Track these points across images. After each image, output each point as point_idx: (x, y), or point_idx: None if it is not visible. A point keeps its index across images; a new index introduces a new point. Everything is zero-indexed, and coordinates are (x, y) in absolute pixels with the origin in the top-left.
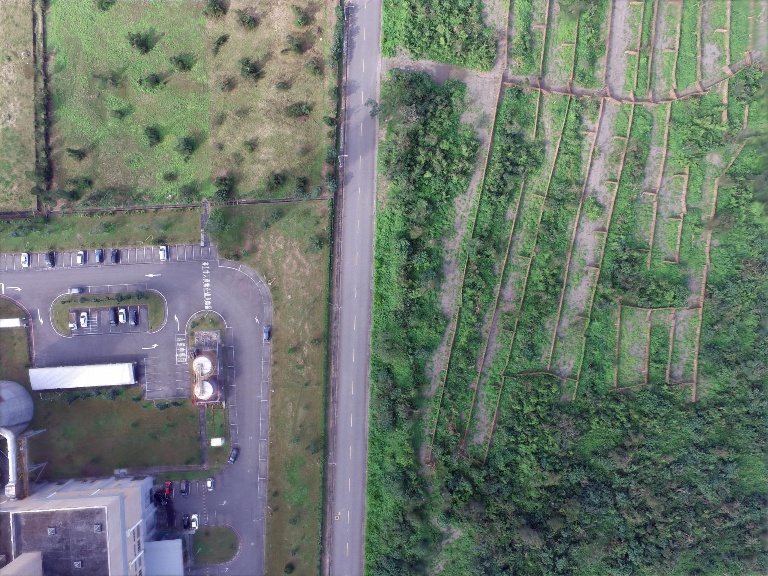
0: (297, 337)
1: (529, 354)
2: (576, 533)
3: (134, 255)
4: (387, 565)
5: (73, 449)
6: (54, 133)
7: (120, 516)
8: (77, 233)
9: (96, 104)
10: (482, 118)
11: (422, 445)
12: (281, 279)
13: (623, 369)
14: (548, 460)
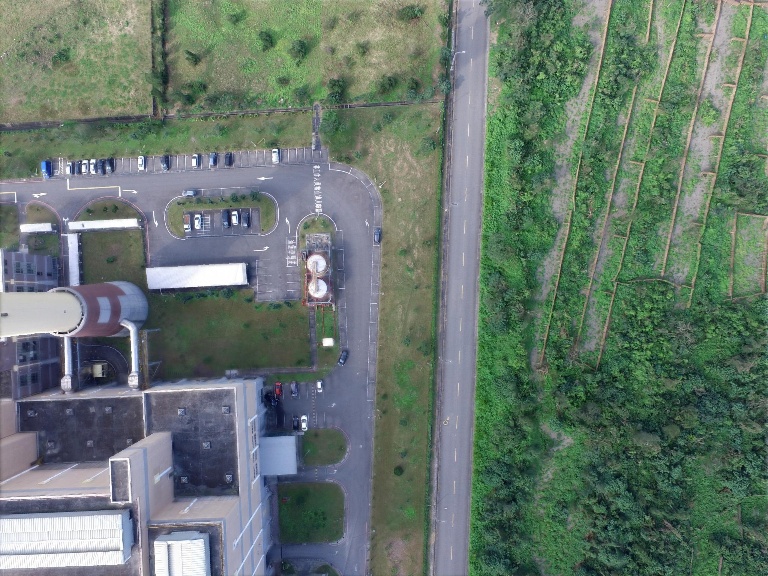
0: (407, 240)
1: (643, 259)
2: (690, 444)
3: (246, 158)
4: (498, 469)
5: (186, 349)
6: (170, 39)
7: (244, 403)
8: (191, 137)
9: (211, 10)
10: (594, 21)
11: (533, 350)
12: (391, 182)
13: (738, 279)
14: (663, 367)
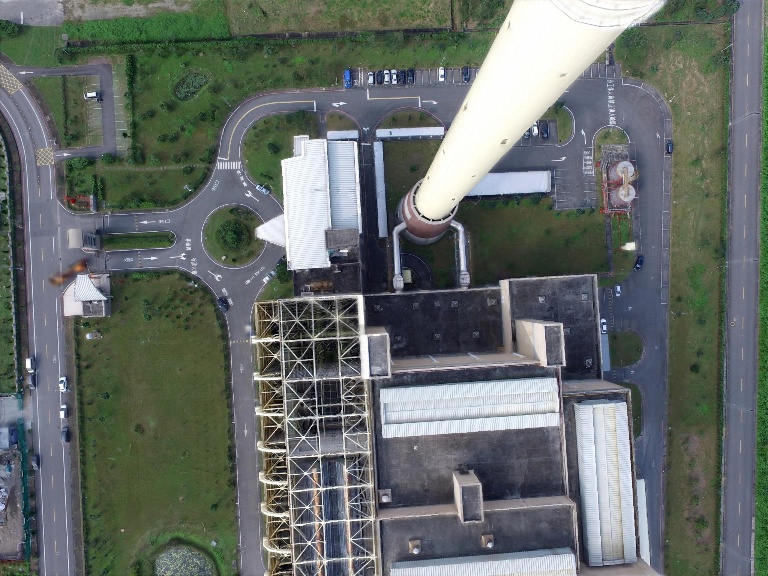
0: (697, 151)
1: None
2: None
3: None
4: None
5: (488, 256)
6: None
7: None
8: None
9: None
10: None
11: None
12: (680, 97)
13: None
14: None
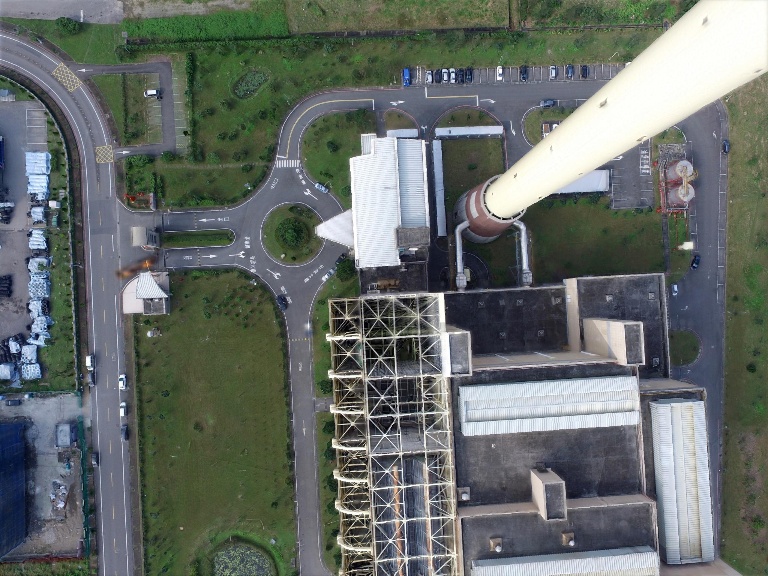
0: (753, 151)
1: None
2: None
3: (600, 71)
4: None
5: (546, 255)
6: None
7: None
8: (548, 49)
9: None
10: None
11: None
12: (737, 96)
13: None
14: None
